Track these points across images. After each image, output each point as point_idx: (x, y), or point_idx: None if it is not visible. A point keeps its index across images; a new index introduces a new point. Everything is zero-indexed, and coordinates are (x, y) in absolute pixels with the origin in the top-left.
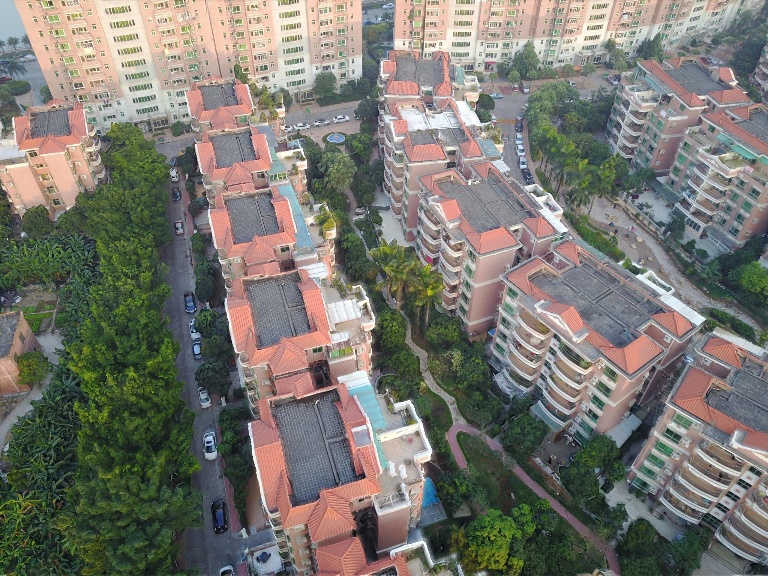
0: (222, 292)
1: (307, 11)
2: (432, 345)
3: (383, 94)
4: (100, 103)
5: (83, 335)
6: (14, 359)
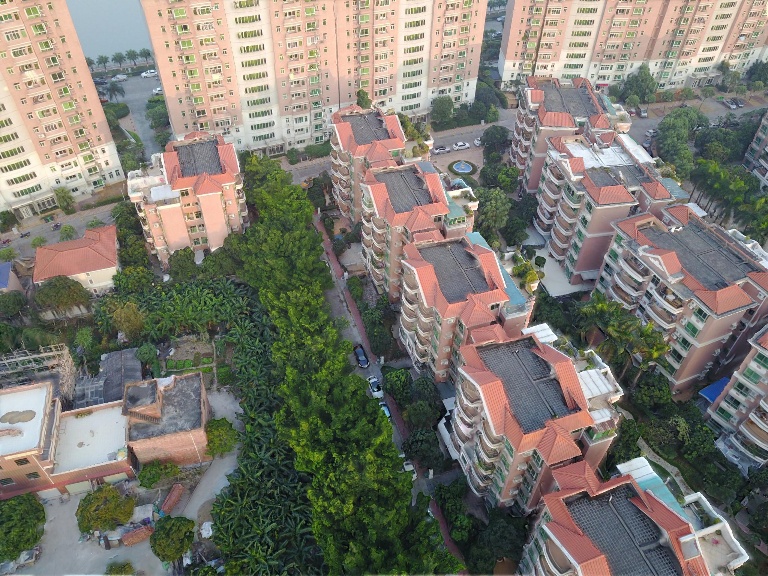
0: (391, 343)
1: (431, 33)
2: (637, 406)
3: (539, 126)
4: (220, 131)
5: (292, 406)
6: None
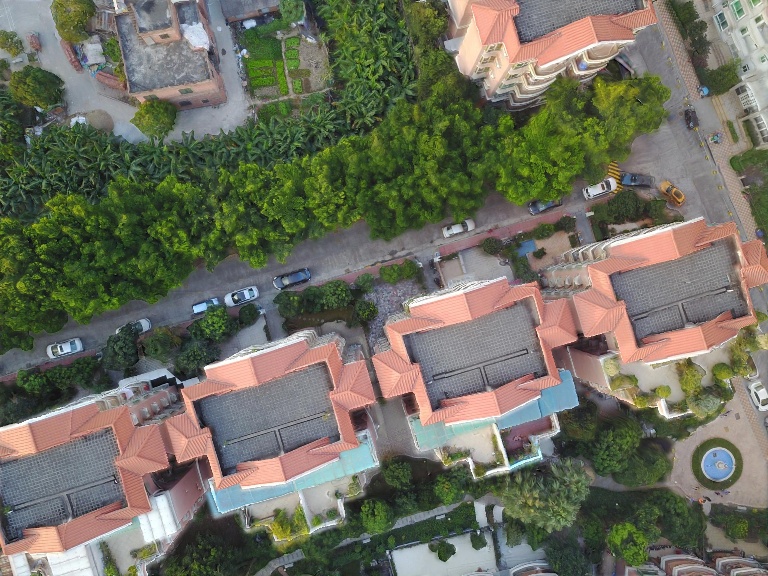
0: (315, 319)
1: None
2: None
3: None
4: (767, 17)
5: (113, 194)
6: (145, 97)
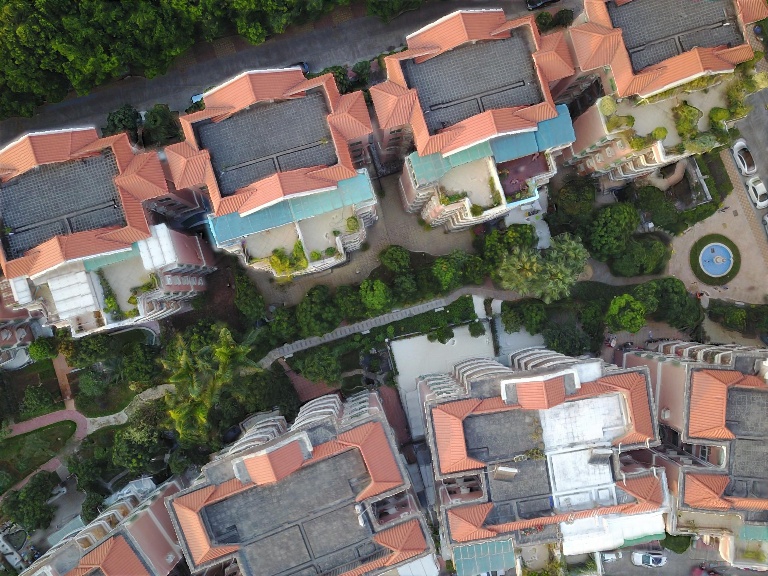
0: None
1: None
2: None
3: None
4: None
5: None
6: None
